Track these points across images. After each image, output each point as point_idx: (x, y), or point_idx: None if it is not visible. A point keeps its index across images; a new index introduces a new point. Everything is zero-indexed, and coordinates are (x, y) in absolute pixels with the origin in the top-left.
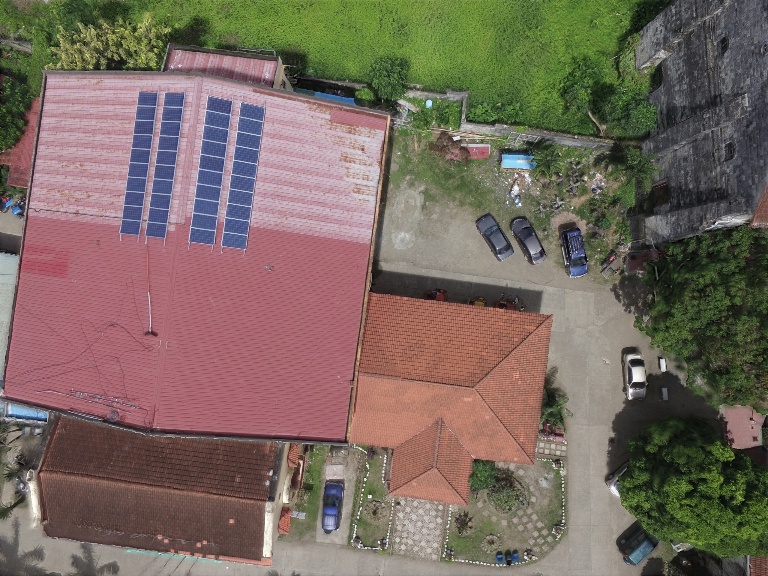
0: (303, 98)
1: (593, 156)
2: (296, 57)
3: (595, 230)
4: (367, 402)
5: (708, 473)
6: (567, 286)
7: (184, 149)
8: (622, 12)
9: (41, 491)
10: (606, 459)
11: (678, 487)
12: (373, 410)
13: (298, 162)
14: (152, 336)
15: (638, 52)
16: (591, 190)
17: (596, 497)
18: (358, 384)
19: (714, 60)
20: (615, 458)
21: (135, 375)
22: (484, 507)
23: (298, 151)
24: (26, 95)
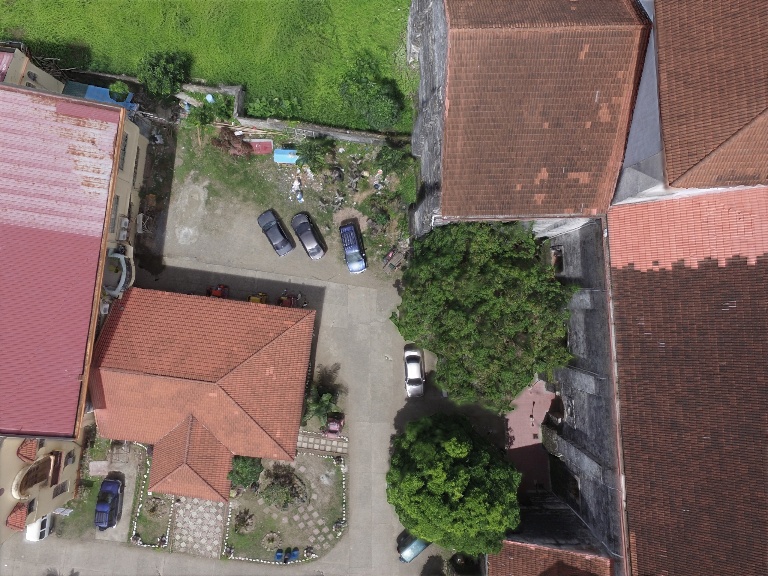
0: (25, 90)
1: (376, 152)
2: (83, 51)
3: (374, 226)
4: (116, 397)
5: (434, 469)
6: (350, 282)
7: None
8: (403, 8)
9: None
10: (388, 456)
11: (410, 483)
12: (123, 405)
13: (19, 154)
14: None
15: (407, 47)
16: (373, 186)
17: (377, 494)
18: (102, 379)
19: (433, 54)
20: None
21: None
22: (265, 504)
23: (19, 143)
24: None
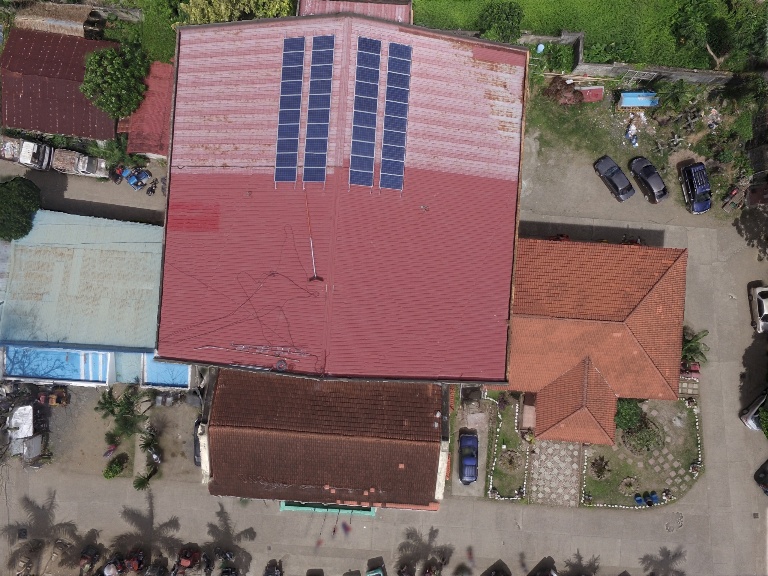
0: (447, 36)
1: (707, 91)
2: None
3: (716, 165)
4: (513, 345)
5: None
6: (689, 224)
7: (337, 91)
8: None
9: (209, 447)
10: (738, 394)
11: None
12: (519, 353)
13: (445, 101)
14: (317, 281)
15: None
16: (707, 126)
17: (731, 433)
18: None
19: None
20: (747, 393)
21: (301, 322)
22: (619, 450)
23: (445, 90)
24: (145, 59)
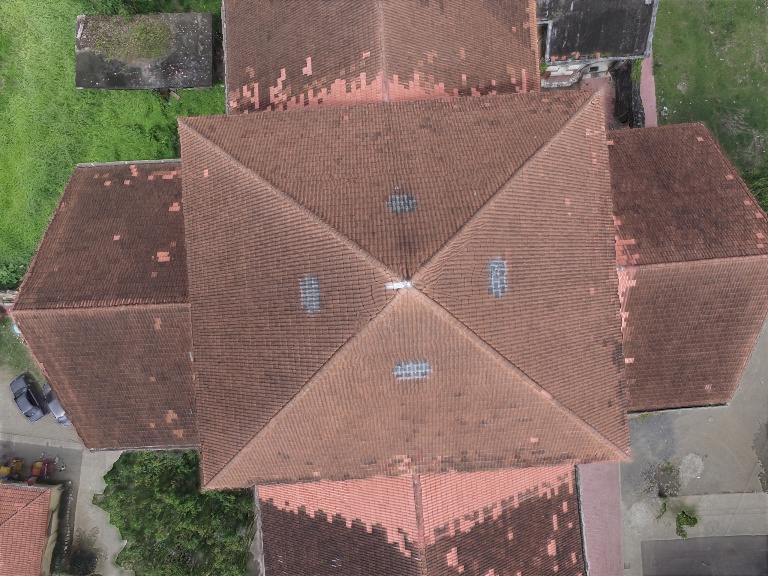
0: None
1: None
2: None
3: None
4: None
5: None
6: None
7: None
8: None
9: None
10: None
11: None
12: None
13: None
14: None
15: None
16: None
17: None
18: None
19: None
20: None
21: None
22: None
23: None
24: None
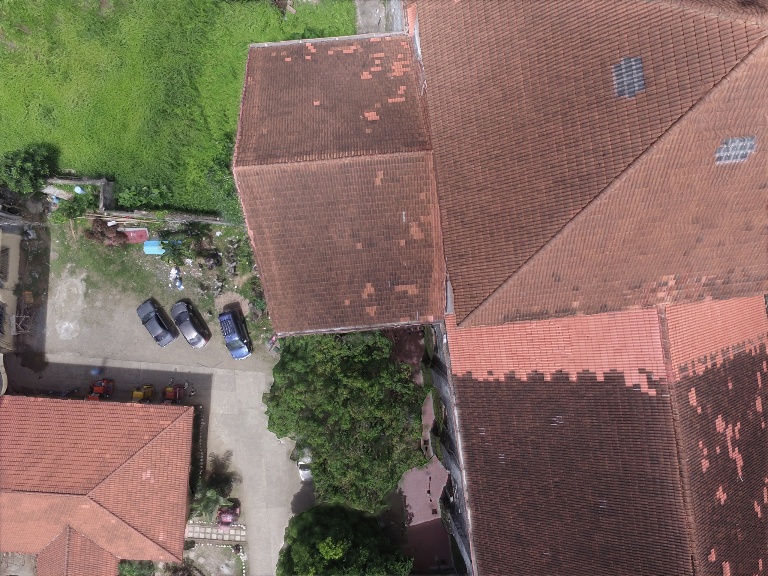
0: None
1: None
2: None
3: (254, 310)
4: None
5: (305, 575)
6: (237, 367)
7: None
8: None
9: None
10: None
11: None
12: None
13: None
14: None
15: None
16: (253, 268)
17: None
18: None
19: None
20: None
21: None
22: None
23: None
24: None
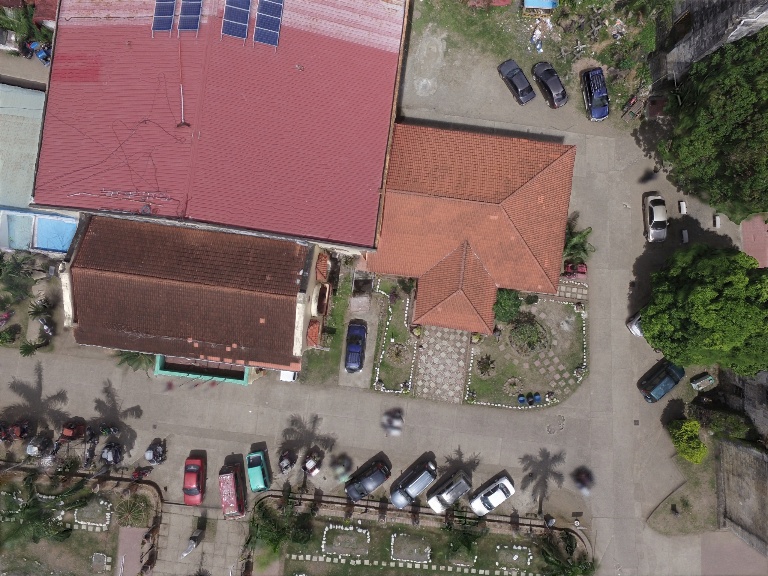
0: None
1: (614, 2)
2: None
3: (616, 73)
4: (393, 223)
5: (733, 276)
6: (588, 131)
7: None
8: None
9: (72, 288)
10: (627, 302)
11: (703, 294)
12: (399, 233)
13: None
14: (184, 127)
15: None
16: (612, 36)
17: (617, 340)
18: (385, 202)
19: None
20: (636, 302)
21: (167, 168)
22: (506, 350)
23: None
24: None
